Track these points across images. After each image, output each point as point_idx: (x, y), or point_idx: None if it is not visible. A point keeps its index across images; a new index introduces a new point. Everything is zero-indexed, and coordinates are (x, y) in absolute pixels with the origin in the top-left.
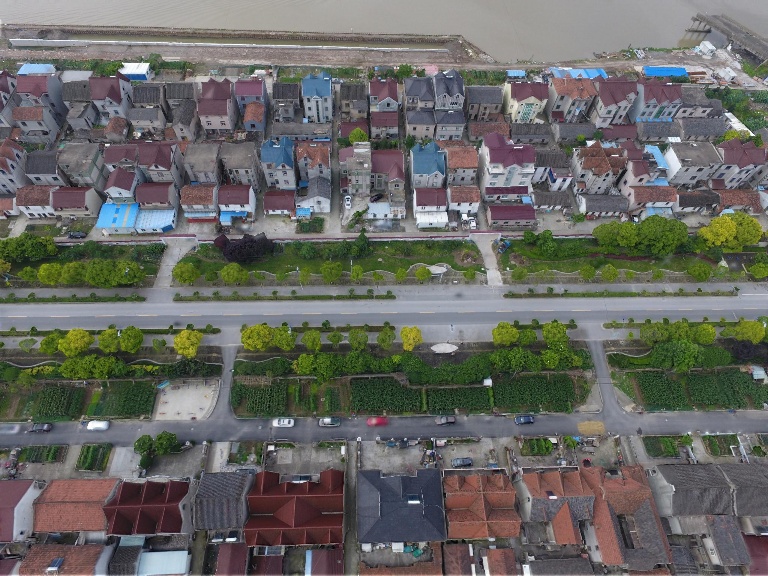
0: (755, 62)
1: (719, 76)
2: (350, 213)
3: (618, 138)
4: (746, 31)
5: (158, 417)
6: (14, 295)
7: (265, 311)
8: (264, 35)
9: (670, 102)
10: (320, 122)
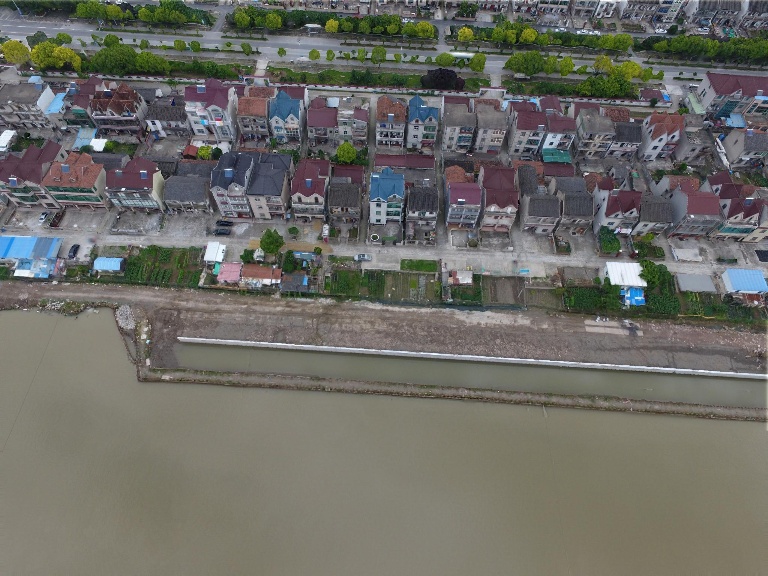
0: None
1: None
2: None
3: None
4: None
5: None
6: None
7: (424, 58)
8: (476, 388)
9: None
10: None
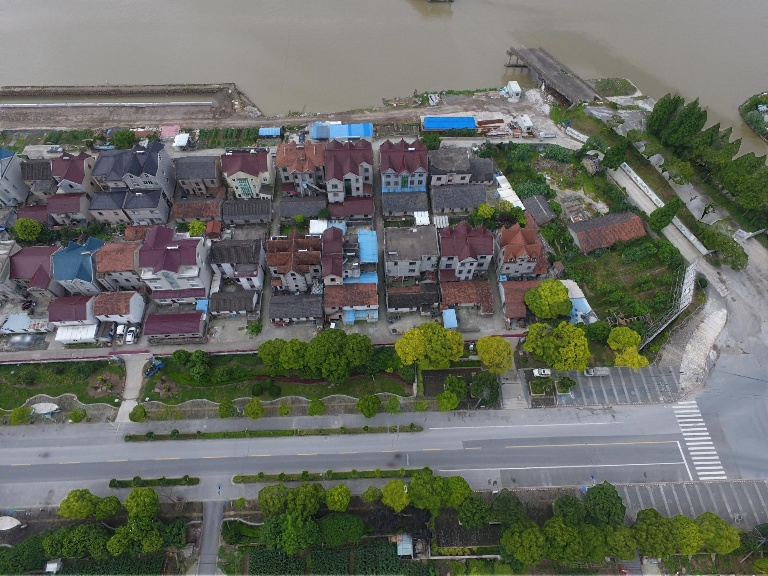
0: (569, 104)
1: (517, 125)
2: None
3: (353, 215)
4: (561, 68)
5: None
6: None
7: None
8: (7, 92)
9: (412, 171)
10: (6, 205)
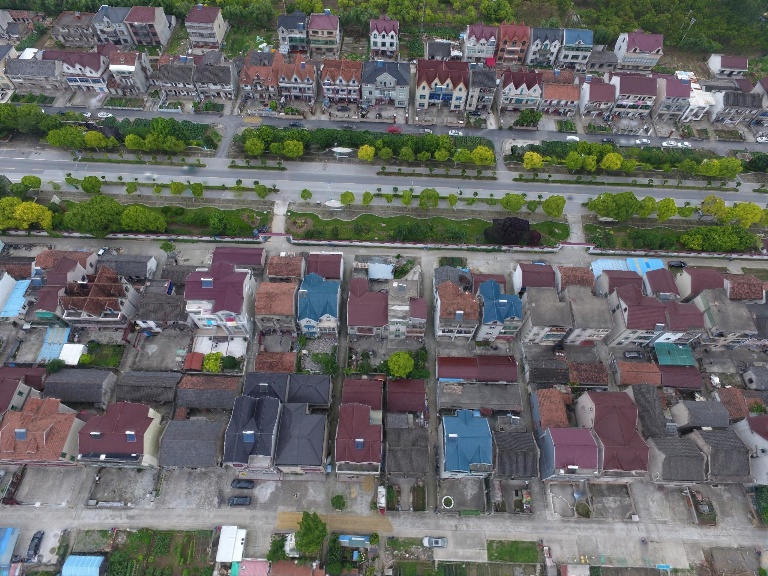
0: None
1: None
2: (412, 278)
3: None
4: None
5: (537, 142)
6: (686, 204)
7: (482, 192)
8: None
9: None
10: None
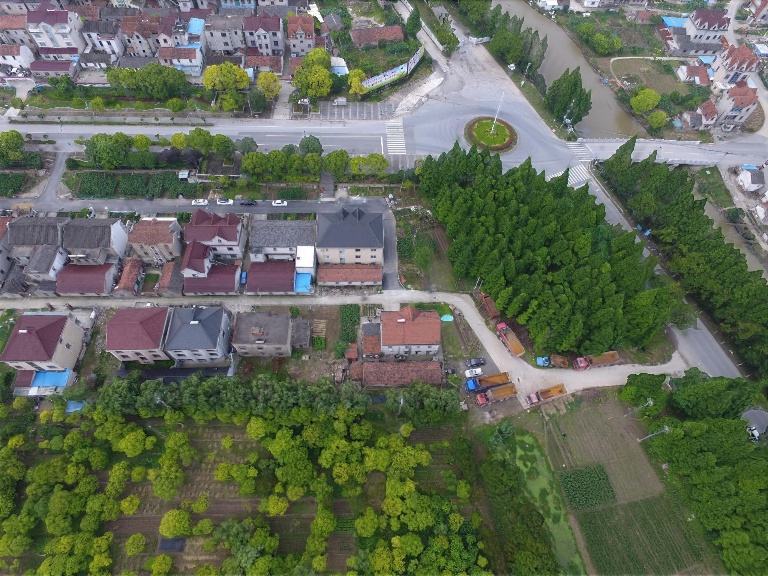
0: None
1: None
2: None
3: None
4: None
5: None
6: None
7: None
8: None
9: None
10: None
